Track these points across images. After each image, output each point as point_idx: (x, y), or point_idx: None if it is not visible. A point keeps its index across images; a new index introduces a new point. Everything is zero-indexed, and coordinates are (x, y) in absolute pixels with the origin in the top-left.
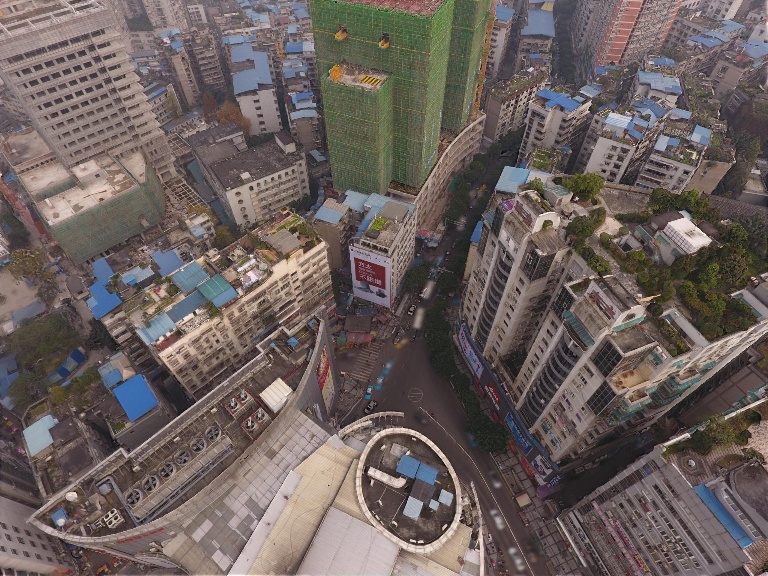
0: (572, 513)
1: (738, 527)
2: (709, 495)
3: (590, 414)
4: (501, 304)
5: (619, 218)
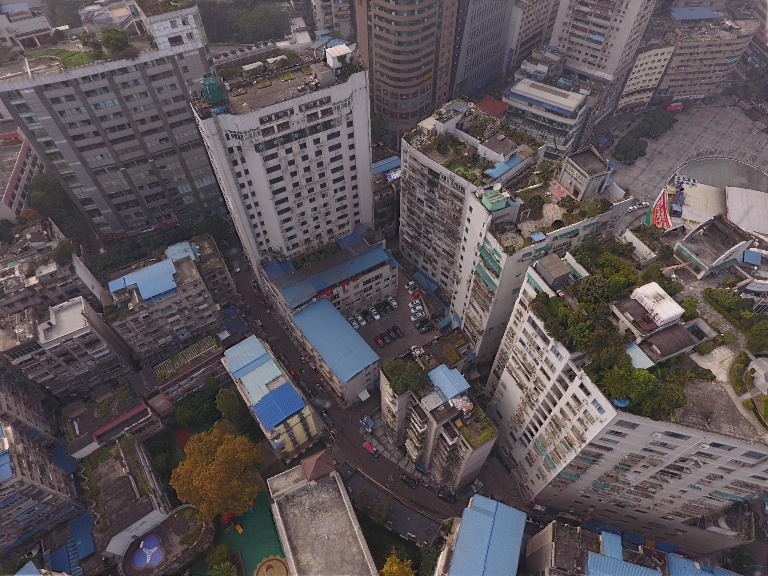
0: None
1: None
2: None
3: None
4: None
5: None
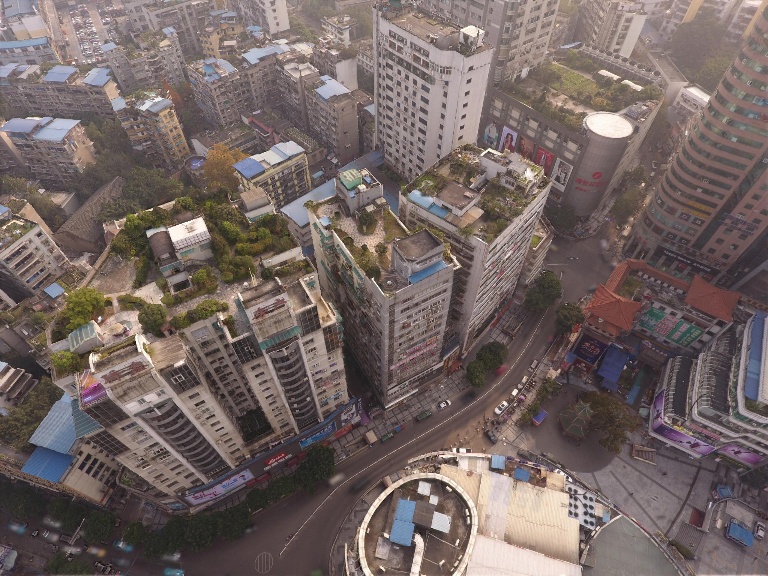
0: (389, 391)
1: (434, 265)
2: (416, 276)
3: (336, 353)
4: (202, 430)
5: (139, 285)
